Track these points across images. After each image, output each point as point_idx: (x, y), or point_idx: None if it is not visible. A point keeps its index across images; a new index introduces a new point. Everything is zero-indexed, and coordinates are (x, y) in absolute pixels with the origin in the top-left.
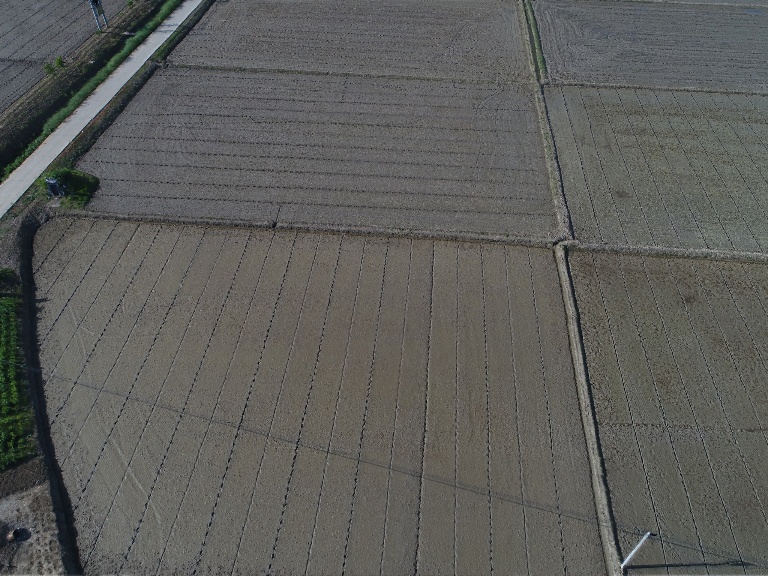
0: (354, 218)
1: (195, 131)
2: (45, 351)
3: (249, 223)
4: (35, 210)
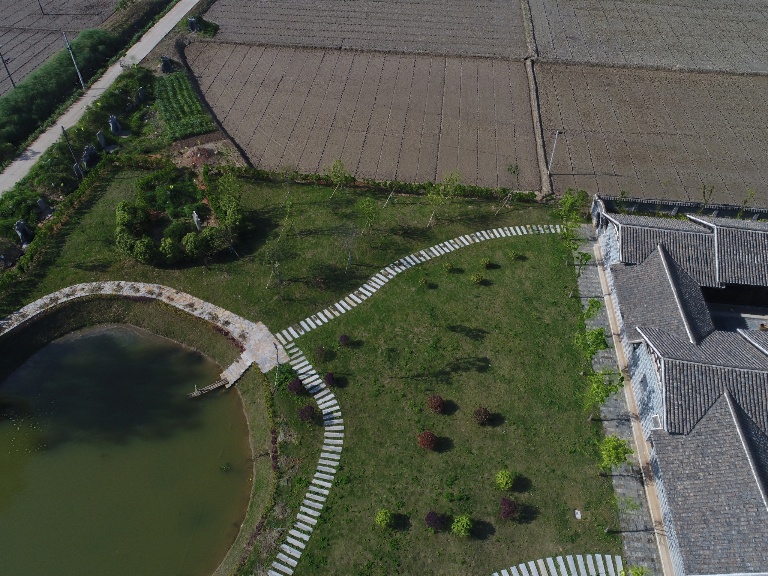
0: (393, 46)
1: (278, 3)
2: (208, 96)
3: (324, 46)
4: (181, 37)
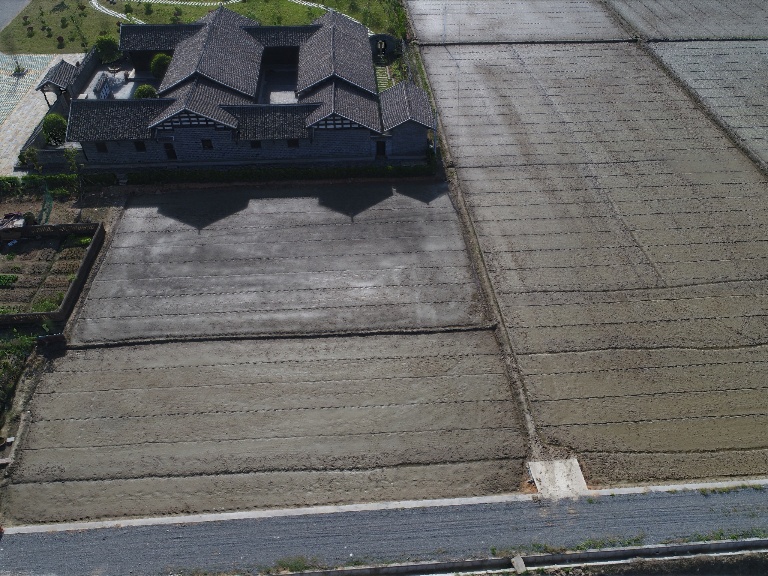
0: None
1: None
2: None
3: None
4: None
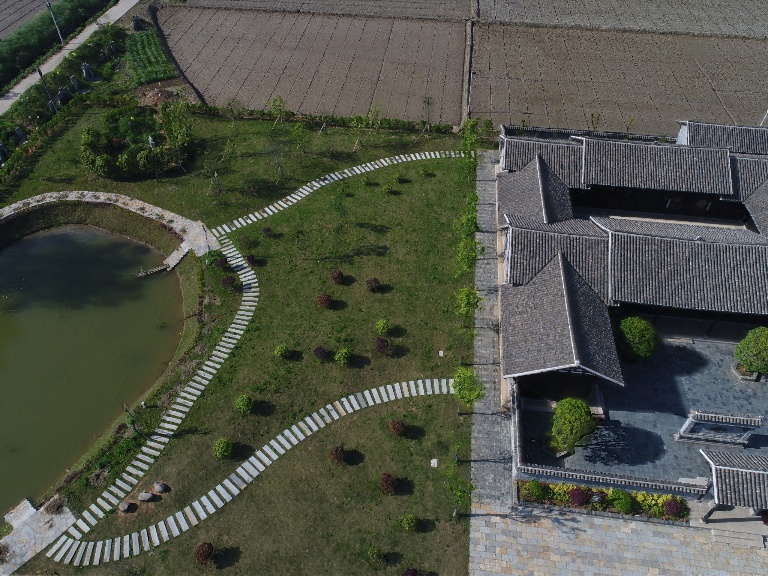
0: (347, 9)
1: None
2: (174, 51)
3: (284, 10)
4: (155, 2)
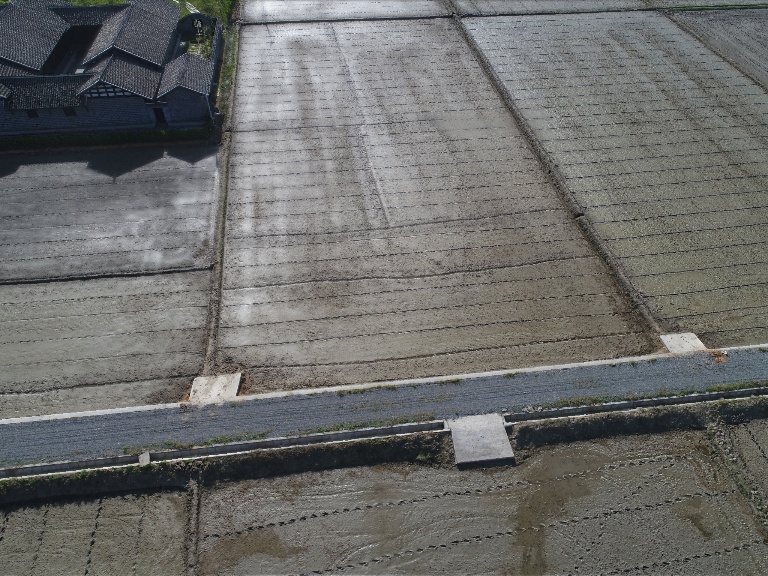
0: None
1: None
2: None
3: None
4: None
